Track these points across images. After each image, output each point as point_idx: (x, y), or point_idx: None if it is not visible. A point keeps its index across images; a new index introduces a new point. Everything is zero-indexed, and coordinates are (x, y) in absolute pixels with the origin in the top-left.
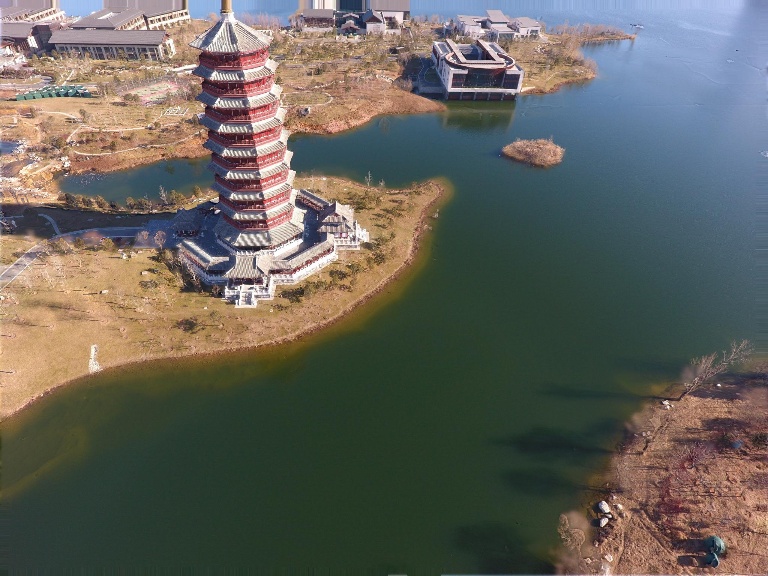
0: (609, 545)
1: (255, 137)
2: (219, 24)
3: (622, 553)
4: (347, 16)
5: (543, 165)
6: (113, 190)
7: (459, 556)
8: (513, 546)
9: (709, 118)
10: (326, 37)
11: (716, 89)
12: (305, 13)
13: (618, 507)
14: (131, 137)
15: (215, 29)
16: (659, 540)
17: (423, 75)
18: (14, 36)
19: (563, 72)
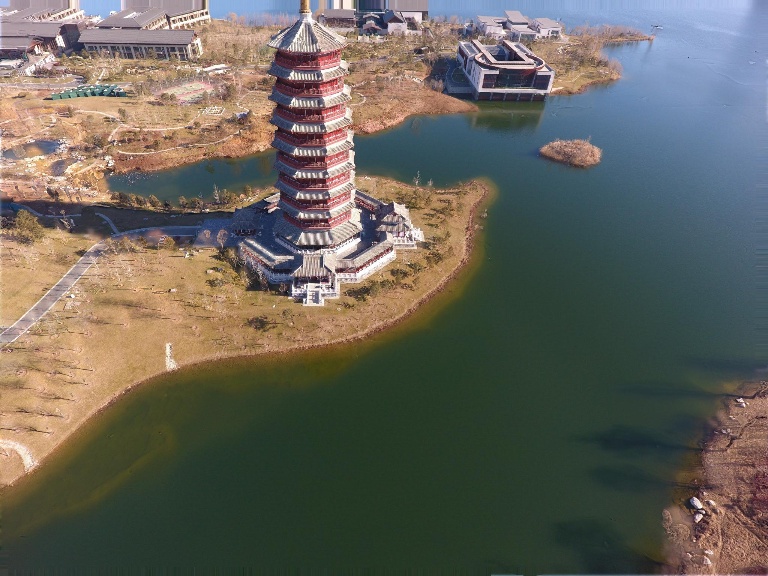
0: (707, 540)
1: (325, 137)
2: (297, 24)
3: (722, 548)
4: (368, 16)
5: (583, 165)
6: (160, 189)
7: (560, 551)
8: (612, 541)
9: (739, 119)
10: (348, 37)
11: (741, 90)
12: (326, 13)
13: (710, 503)
14: (172, 136)
15: (293, 29)
16: (757, 535)
17: (450, 75)
18: (43, 35)
19: (589, 73)
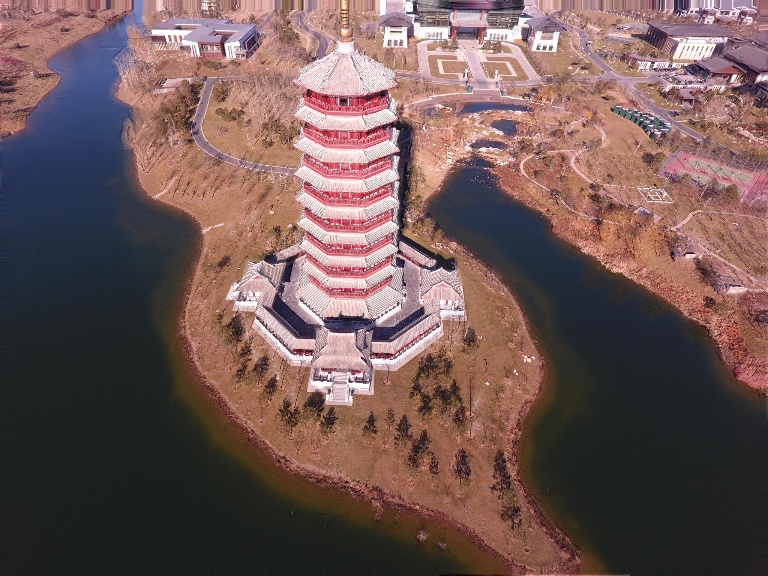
0: None
1: None
2: None
3: None
4: None
5: None
6: (466, 197)
7: None
8: None
9: None
10: None
11: None
12: None
13: None
14: None
15: None
16: None
17: None
18: (752, 67)
19: None
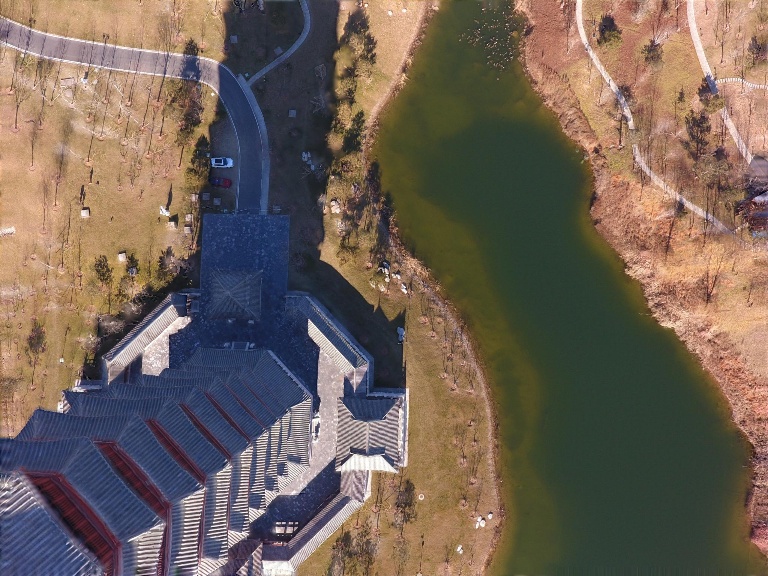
0: None
1: None
2: None
3: None
4: None
5: None
6: (453, 97)
7: None
8: None
9: None
10: None
11: None
12: None
13: None
14: None
15: None
16: None
17: None
18: None
19: None
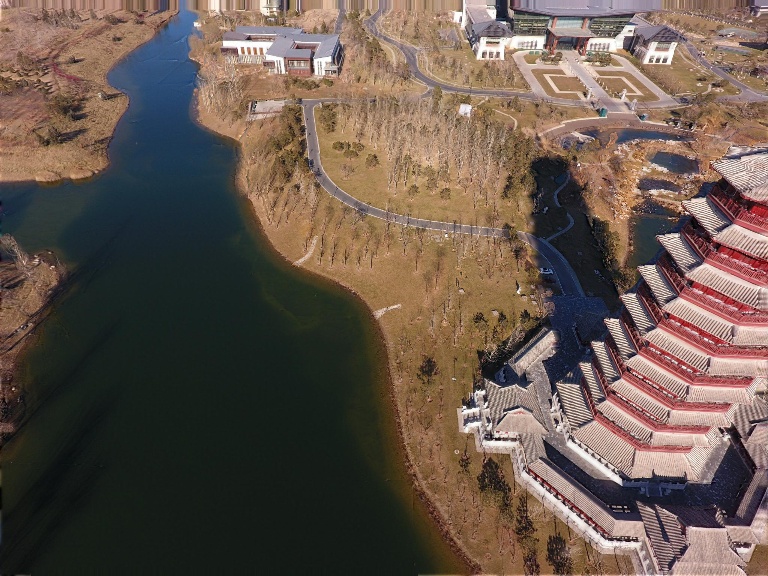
0: None
1: (676, 318)
2: None
3: None
4: None
5: None
6: None
7: None
8: None
9: None
10: None
11: None
12: None
13: None
14: None
15: None
16: None
17: None
18: None
19: None
